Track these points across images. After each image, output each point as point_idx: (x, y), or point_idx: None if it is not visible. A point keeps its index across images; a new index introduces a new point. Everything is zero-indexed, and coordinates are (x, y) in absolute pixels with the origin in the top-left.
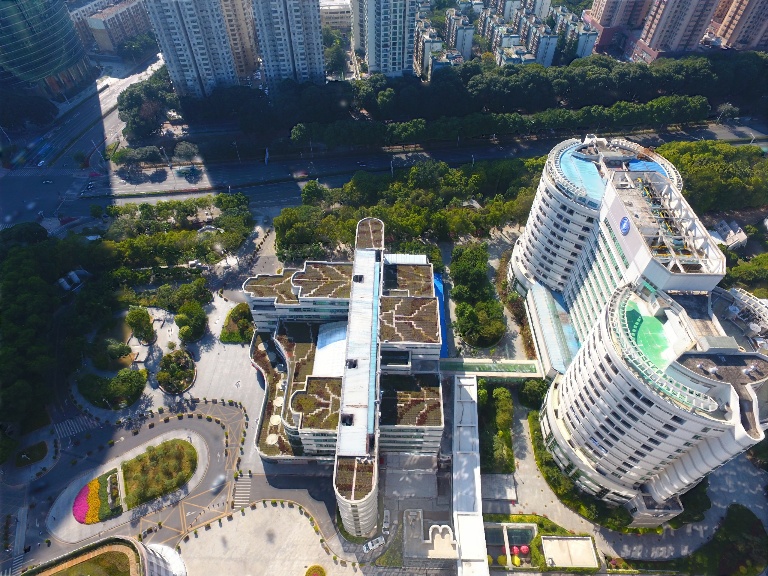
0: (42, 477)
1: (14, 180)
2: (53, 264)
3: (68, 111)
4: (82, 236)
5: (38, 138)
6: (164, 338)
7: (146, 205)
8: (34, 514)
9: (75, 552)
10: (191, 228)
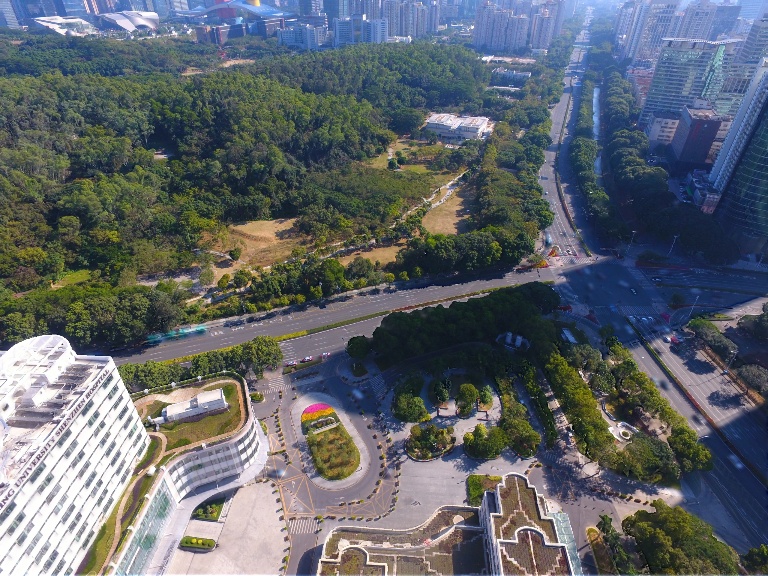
0: (342, 380)
1: (624, 273)
2: (518, 321)
3: (749, 270)
4: (554, 328)
5: (690, 266)
6: (466, 425)
7: (632, 364)
8: (316, 385)
9: (247, 399)
10: (626, 415)
